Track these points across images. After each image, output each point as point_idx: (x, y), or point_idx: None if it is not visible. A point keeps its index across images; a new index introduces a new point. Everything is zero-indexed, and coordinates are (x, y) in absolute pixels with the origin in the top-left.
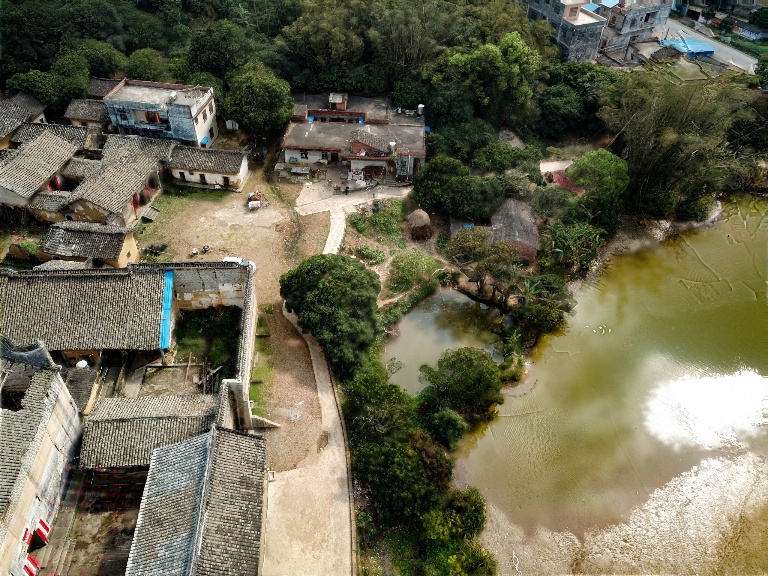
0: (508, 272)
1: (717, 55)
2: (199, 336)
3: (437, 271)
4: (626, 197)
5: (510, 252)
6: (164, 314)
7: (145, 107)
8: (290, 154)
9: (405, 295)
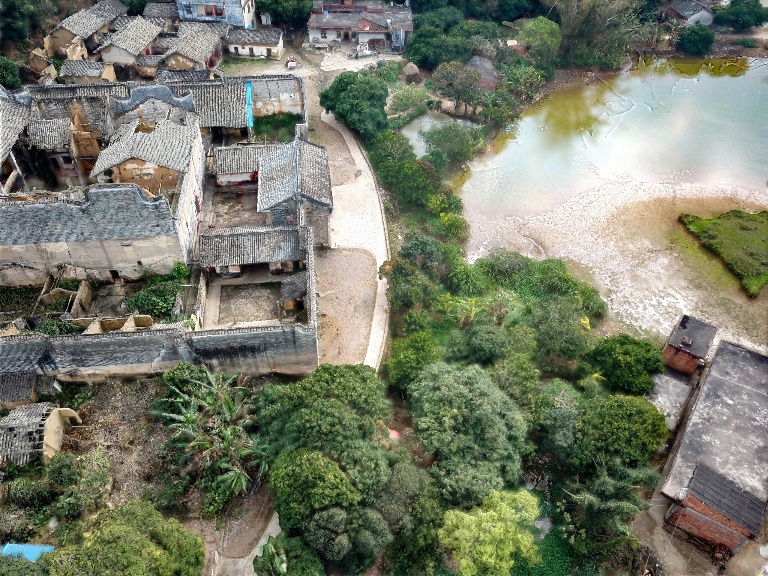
0: (475, 91)
1: None
2: (269, 127)
3: (426, 101)
4: (562, 56)
5: (475, 75)
6: (248, 107)
7: (206, 2)
8: (313, 35)
9: (404, 113)
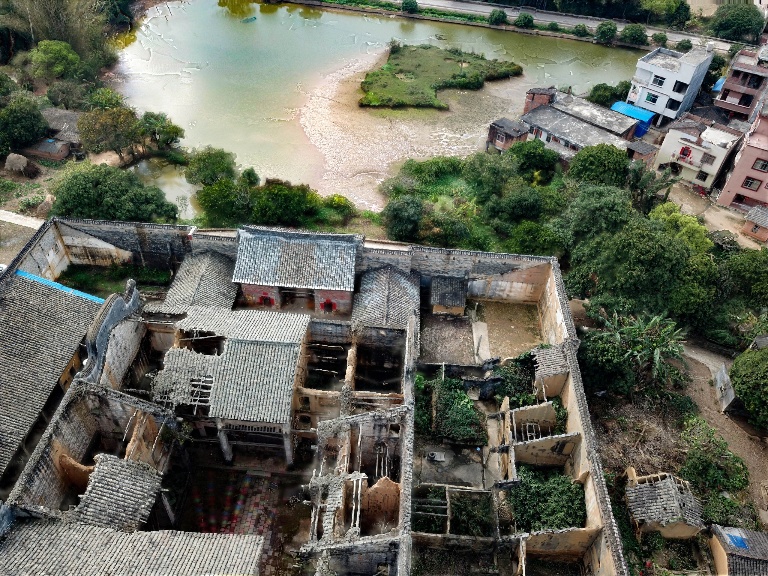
0: None
1: None
2: None
3: None
4: None
5: None
6: (66, 291)
7: None
8: None
9: None
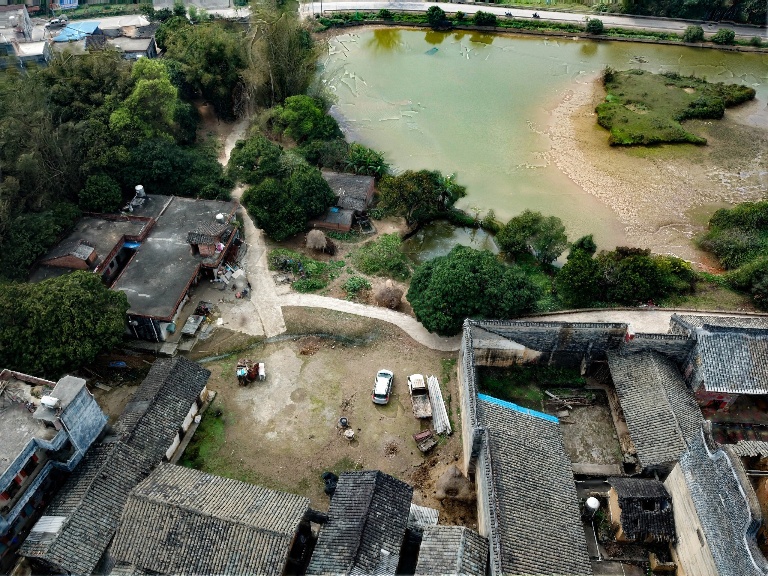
0: None
1: (106, 25)
2: None
3: None
4: None
5: None
6: (524, 412)
7: (12, 474)
8: (164, 325)
9: None
